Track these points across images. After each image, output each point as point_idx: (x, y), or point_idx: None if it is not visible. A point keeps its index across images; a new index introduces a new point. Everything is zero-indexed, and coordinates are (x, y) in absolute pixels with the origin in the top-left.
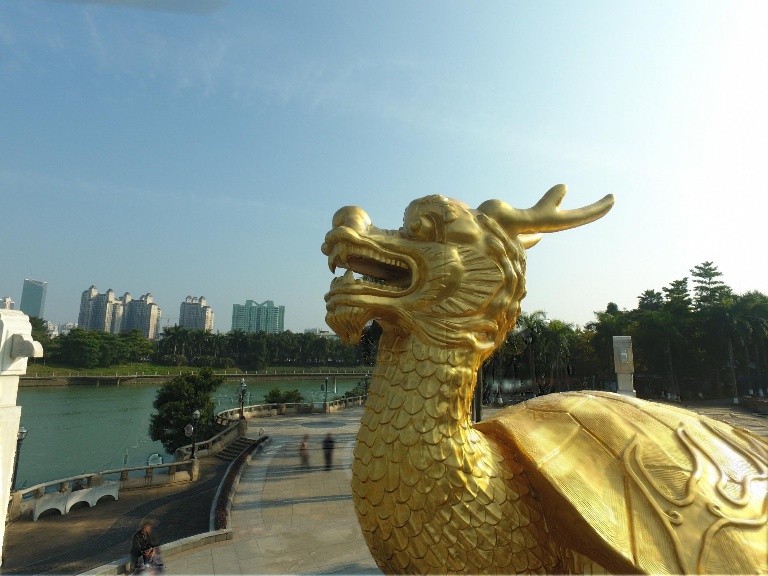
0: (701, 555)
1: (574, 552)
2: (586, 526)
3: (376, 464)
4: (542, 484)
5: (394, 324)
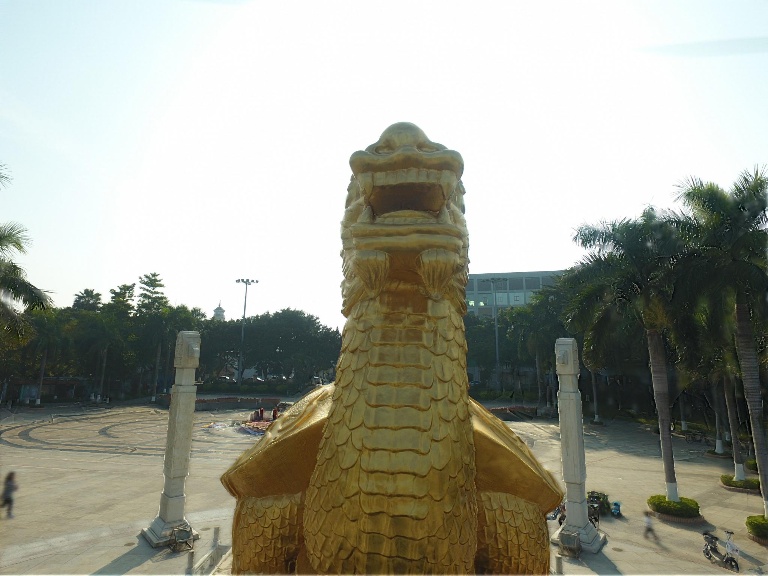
0: (540, 467)
1: (490, 493)
2: (521, 465)
3: (439, 449)
4: (478, 443)
5: (422, 285)
